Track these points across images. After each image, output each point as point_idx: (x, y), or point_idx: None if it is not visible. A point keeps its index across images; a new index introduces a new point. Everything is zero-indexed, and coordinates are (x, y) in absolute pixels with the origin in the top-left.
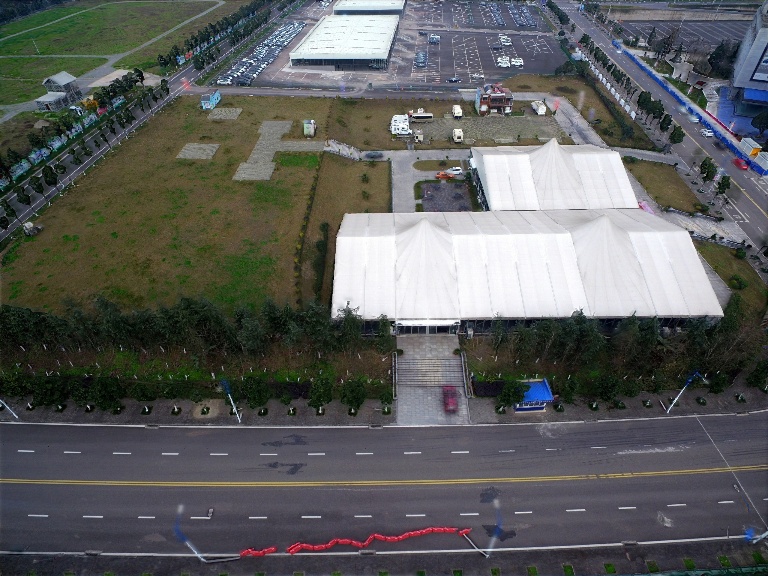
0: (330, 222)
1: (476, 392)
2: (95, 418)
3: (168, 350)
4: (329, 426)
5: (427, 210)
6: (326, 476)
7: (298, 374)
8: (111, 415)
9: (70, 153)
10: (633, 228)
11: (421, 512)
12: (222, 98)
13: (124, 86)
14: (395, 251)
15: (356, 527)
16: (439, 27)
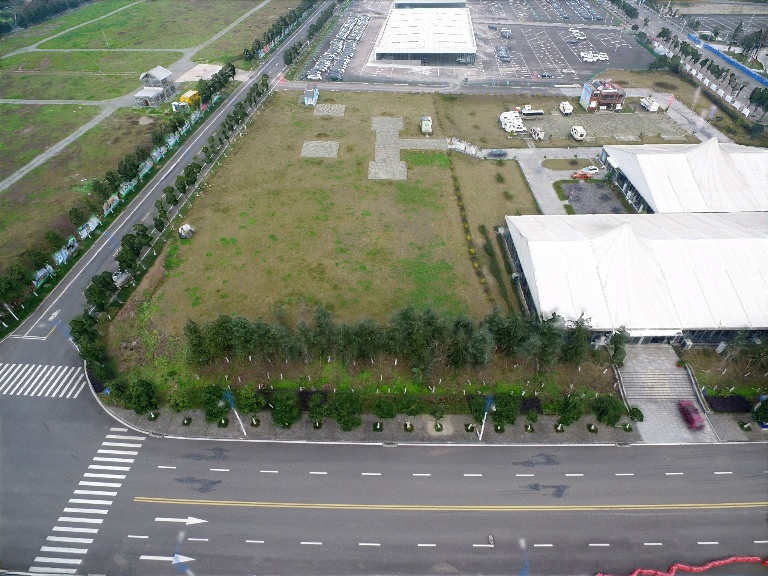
0: (484, 224)
1: (714, 407)
2: (327, 435)
3: (378, 361)
4: (574, 444)
5: (578, 211)
6: (595, 499)
7: (519, 387)
8: (342, 432)
9: (203, 151)
10: None
11: (711, 539)
12: (319, 94)
13: (221, 81)
14: (594, 257)
15: (651, 556)
16: (504, 21)
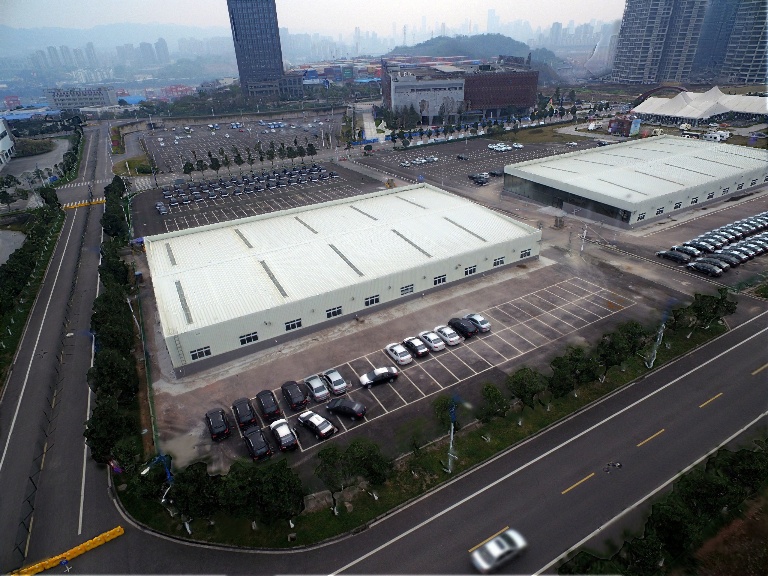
0: None
1: None
2: None
3: None
4: None
5: (752, 123)
6: None
7: None
8: None
9: None
10: (696, 94)
11: None
12: None
13: None
14: None
15: None
16: None
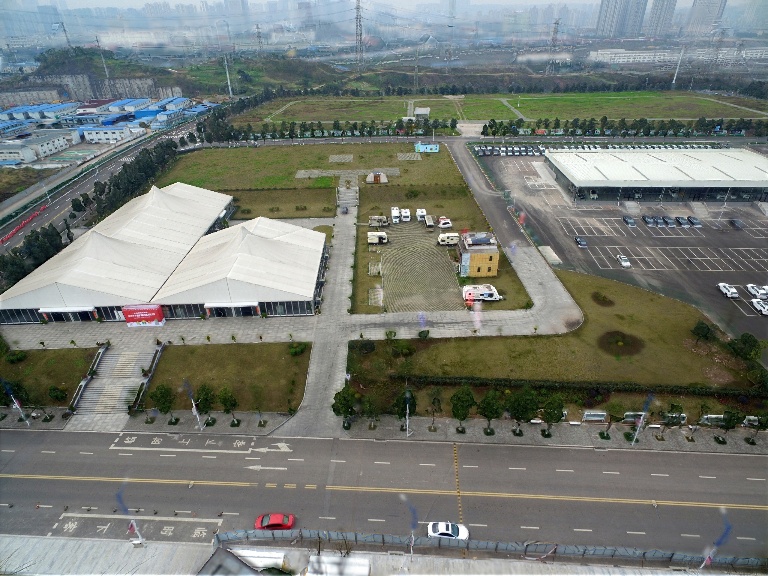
0: (243, 202)
1: None
2: None
3: None
4: None
5: None
6: None
7: None
8: None
9: None
10: (93, 264)
11: None
12: (441, 152)
13: (429, 125)
14: None
15: None
16: None
